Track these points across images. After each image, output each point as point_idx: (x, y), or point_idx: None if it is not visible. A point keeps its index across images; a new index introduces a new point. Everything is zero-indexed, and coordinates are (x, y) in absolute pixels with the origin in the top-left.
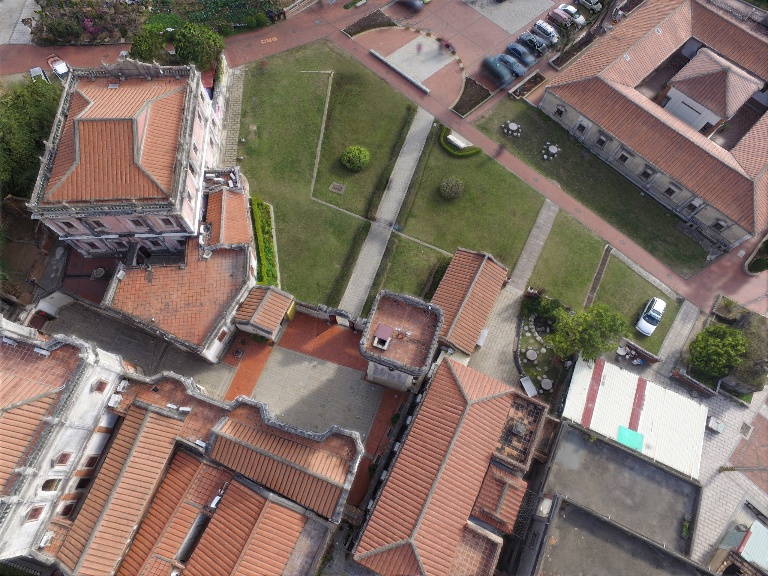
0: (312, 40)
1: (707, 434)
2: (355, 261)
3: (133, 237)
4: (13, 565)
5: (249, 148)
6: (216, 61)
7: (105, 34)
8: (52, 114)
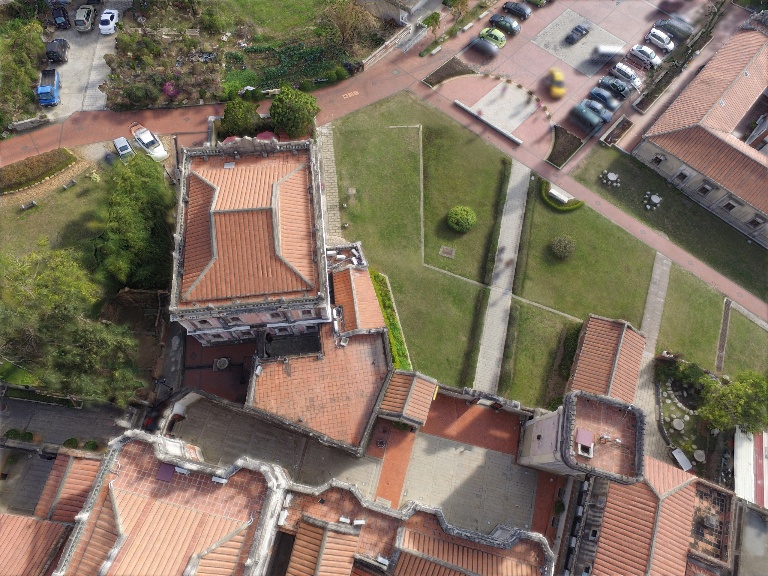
0: (394, 92)
1: None
2: (482, 332)
3: (264, 327)
4: None
5: (352, 214)
6: (310, 124)
7: (182, 95)
8: (159, 195)
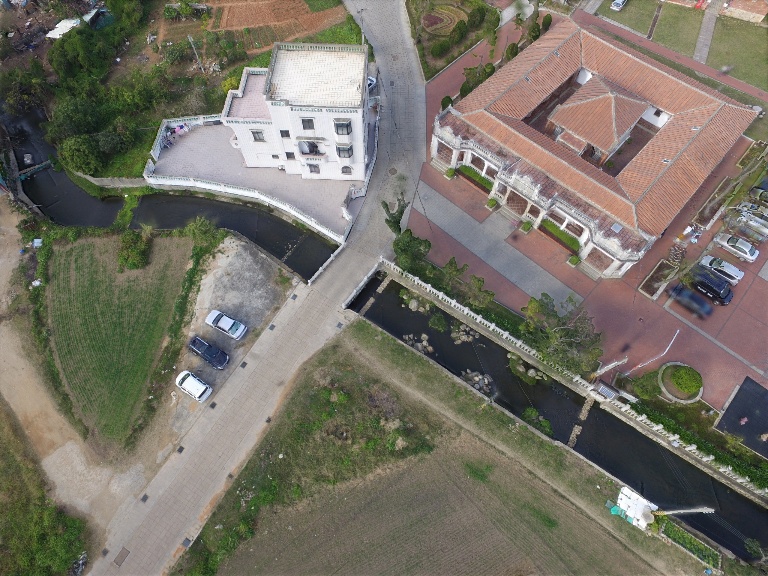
0: None
1: None
2: None
3: None
4: None
5: None
6: None
7: None
8: None
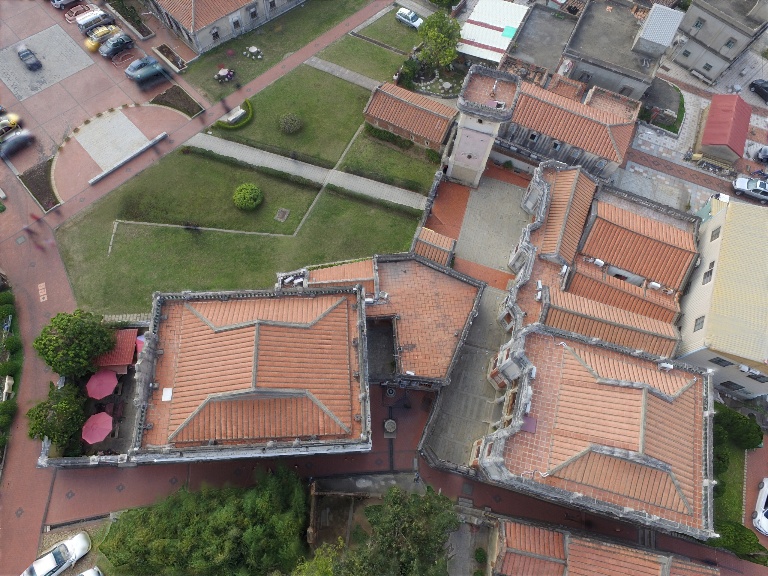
0: (54, 244)
1: None
2: None
3: None
4: None
5: None
6: None
7: None
8: None
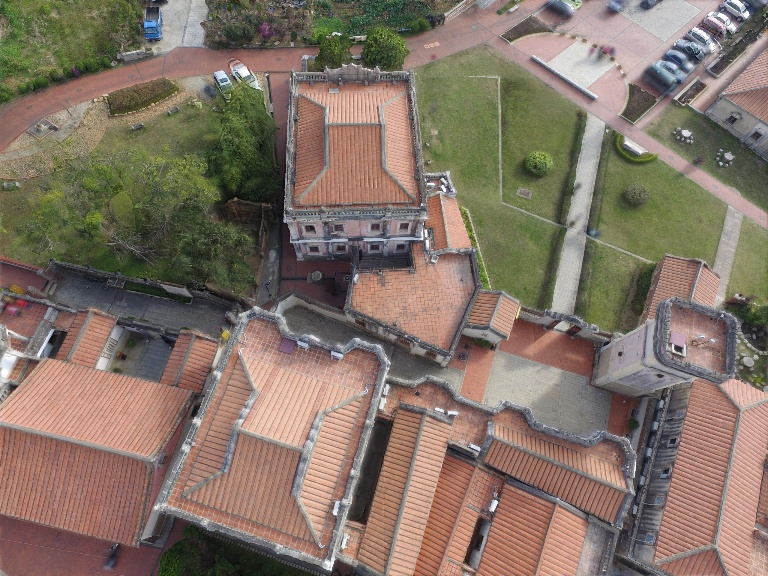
0: (473, 45)
1: None
2: (558, 266)
3: (360, 241)
4: (298, 567)
5: (434, 153)
6: (399, 66)
7: (274, 38)
8: None
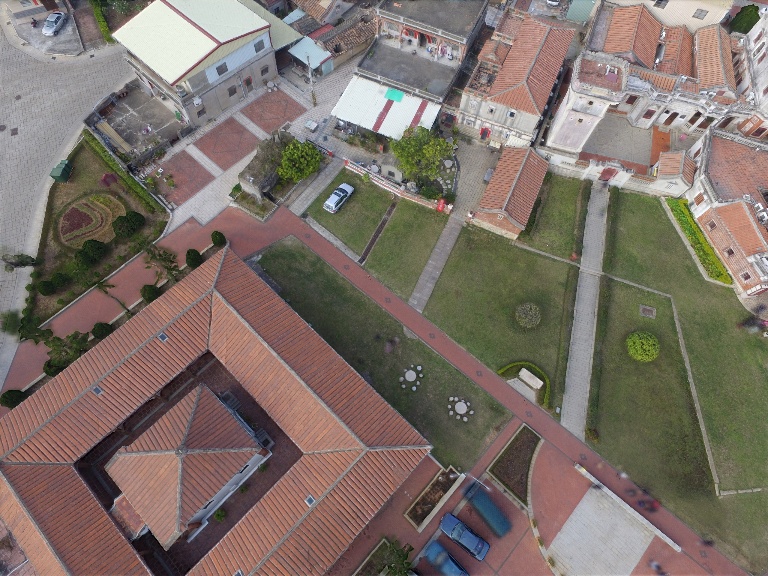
0: None
1: (318, 124)
2: None
3: None
4: None
5: (764, 350)
6: None
7: None
8: None
